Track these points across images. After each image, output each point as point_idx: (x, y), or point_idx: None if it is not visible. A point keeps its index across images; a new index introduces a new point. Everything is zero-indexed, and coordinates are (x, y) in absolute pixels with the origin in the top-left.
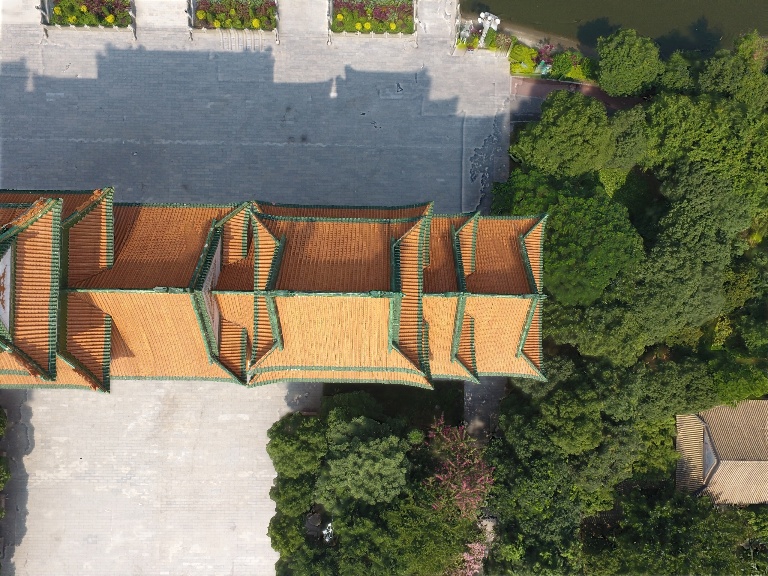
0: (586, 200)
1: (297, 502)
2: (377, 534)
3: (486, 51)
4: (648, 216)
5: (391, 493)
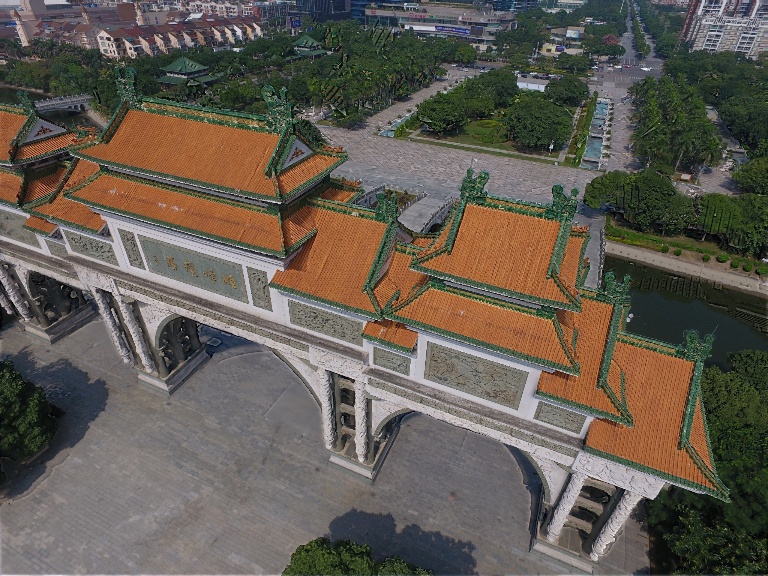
0: None
1: None
2: None
3: None
4: None
5: None
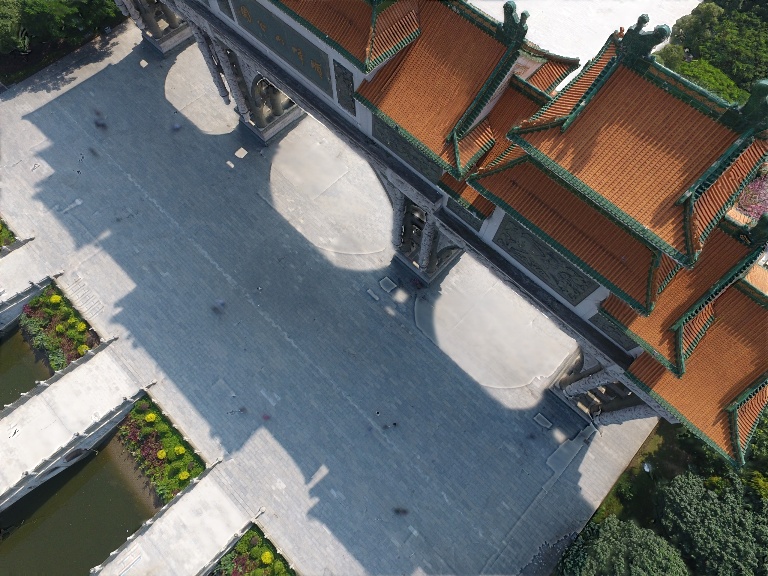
0: None
1: None
2: None
3: None
4: None
5: None
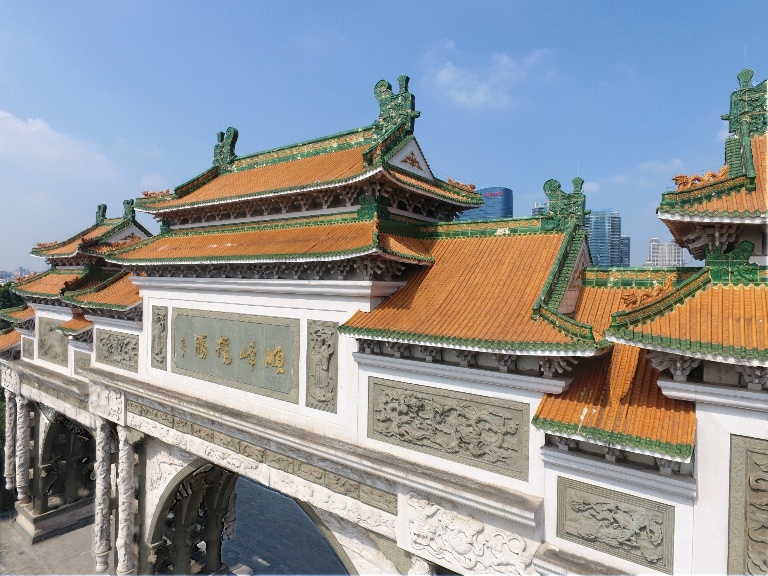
0: None
1: None
2: None
3: None
4: None
5: None
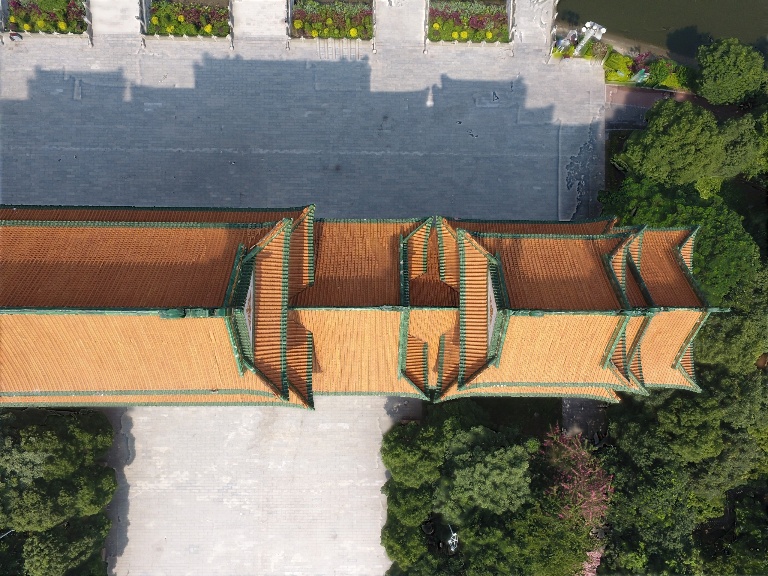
0: (705, 209)
1: (419, 512)
2: (507, 544)
3: (581, 59)
4: (754, 224)
5: (516, 502)
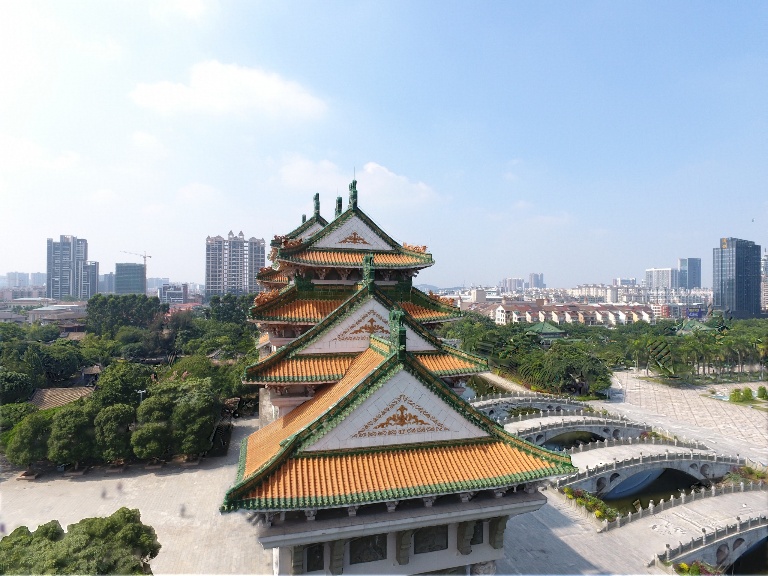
0: None
1: None
2: None
3: None
4: None
5: None
